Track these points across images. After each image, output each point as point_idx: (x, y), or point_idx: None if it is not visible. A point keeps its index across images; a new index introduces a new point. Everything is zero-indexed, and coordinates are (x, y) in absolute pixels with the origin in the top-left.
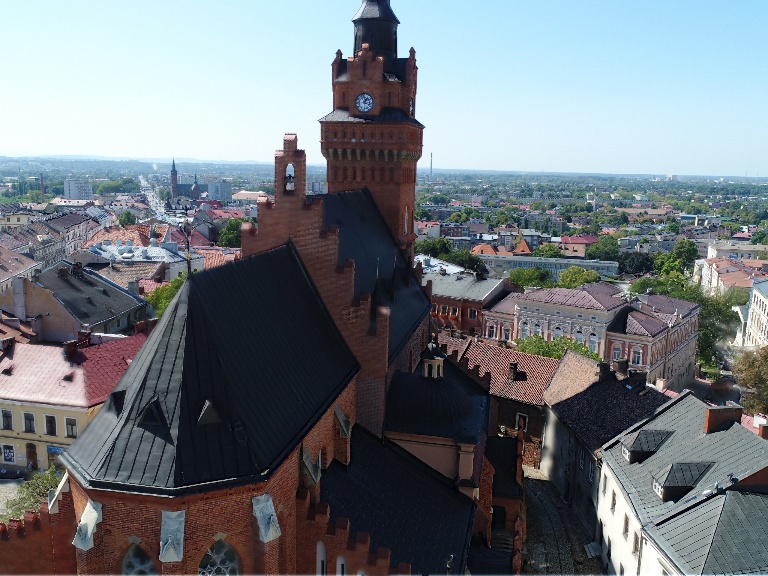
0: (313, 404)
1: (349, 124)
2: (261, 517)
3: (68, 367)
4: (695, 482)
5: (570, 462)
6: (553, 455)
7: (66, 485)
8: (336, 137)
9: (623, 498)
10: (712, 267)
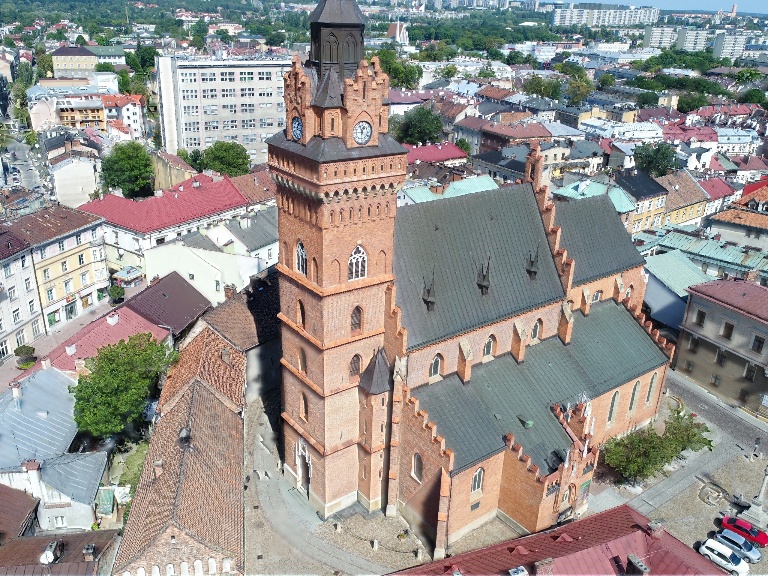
0: None
1: None
2: None
3: None
4: None
5: None
6: None
7: None
8: None
9: None
10: None
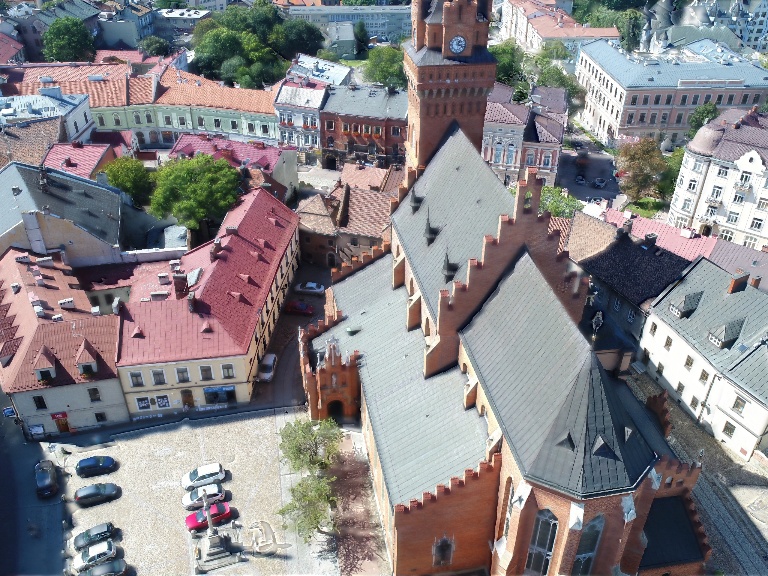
0: None
1: (445, 67)
2: None
3: (199, 319)
4: (739, 334)
5: None
6: None
7: None
8: (432, 79)
9: (691, 348)
10: (518, 10)
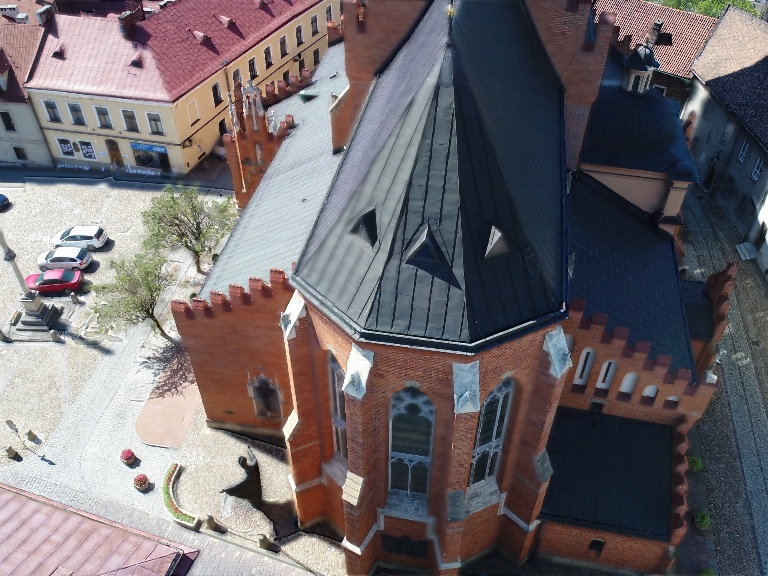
0: (556, 175)
1: None
2: (555, 353)
3: (131, 48)
4: None
5: (721, 150)
6: (694, 136)
7: (302, 311)
8: None
9: None
10: None
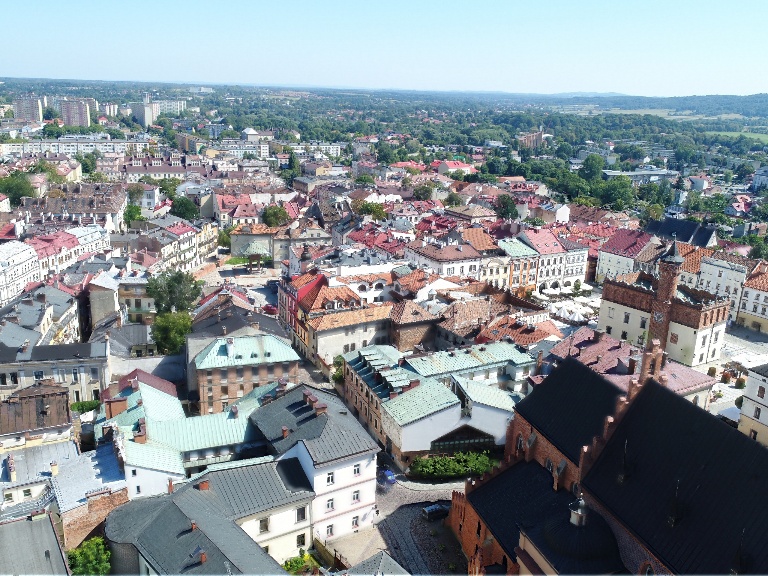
0: None
1: None
2: None
3: None
4: None
5: None
6: None
7: None
8: None
9: None
10: None
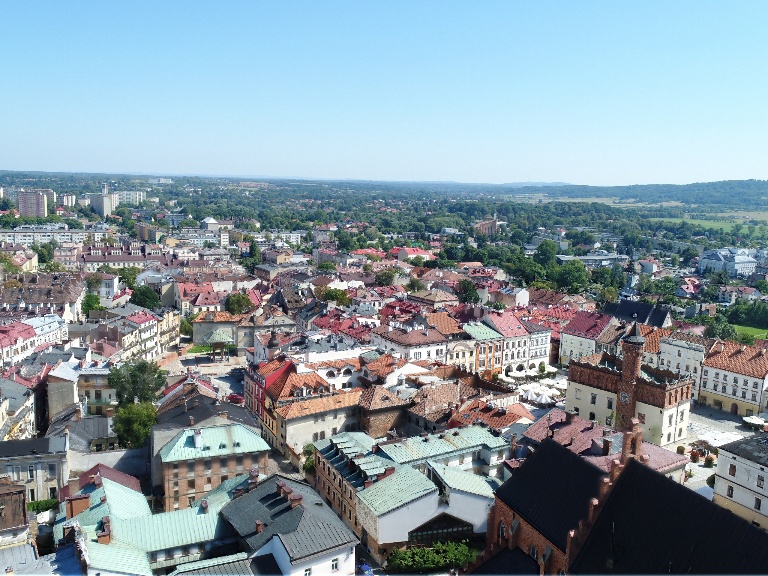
0: None
1: None
2: None
3: None
4: None
5: None
6: None
7: None
8: None
9: None
10: None
